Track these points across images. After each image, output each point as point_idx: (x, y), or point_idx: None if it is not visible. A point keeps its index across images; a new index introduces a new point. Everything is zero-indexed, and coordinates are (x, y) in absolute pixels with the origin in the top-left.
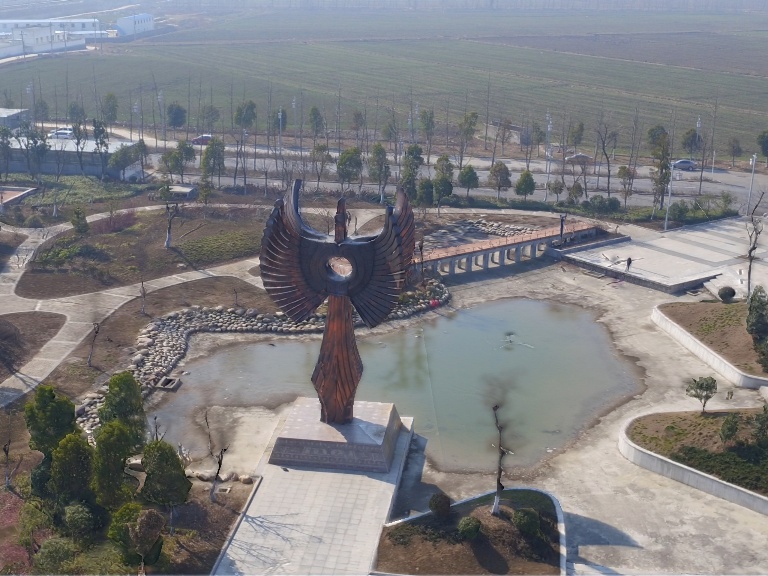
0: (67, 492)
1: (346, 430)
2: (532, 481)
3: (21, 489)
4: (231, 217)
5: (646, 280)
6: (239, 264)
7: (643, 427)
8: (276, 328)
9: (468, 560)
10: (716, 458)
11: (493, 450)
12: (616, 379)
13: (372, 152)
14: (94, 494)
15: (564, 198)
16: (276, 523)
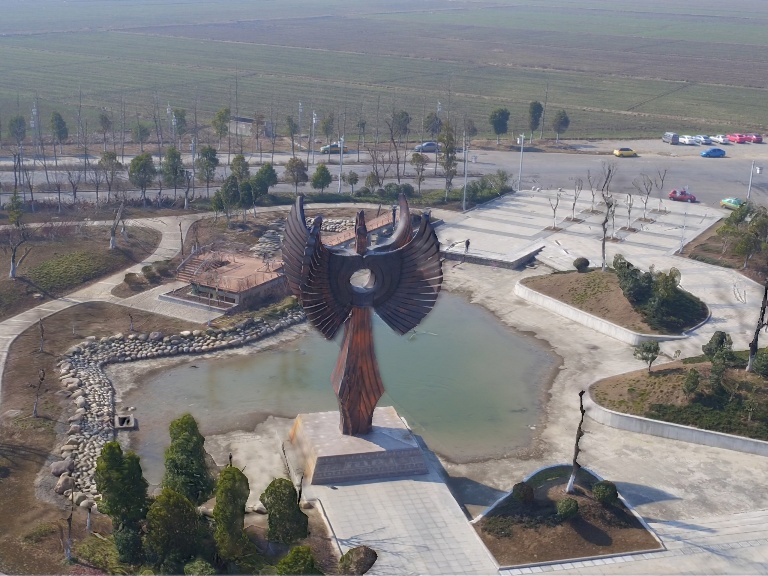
0: (176, 551)
1: (375, 439)
2: (542, 458)
3: (90, 559)
4: (54, 238)
5: (488, 259)
6: (95, 287)
7: (604, 393)
8: (188, 349)
9: (574, 538)
10: (686, 410)
11: (485, 436)
12: (531, 354)
13: (167, 157)
14: (201, 547)
15: (358, 188)
16: (373, 541)
